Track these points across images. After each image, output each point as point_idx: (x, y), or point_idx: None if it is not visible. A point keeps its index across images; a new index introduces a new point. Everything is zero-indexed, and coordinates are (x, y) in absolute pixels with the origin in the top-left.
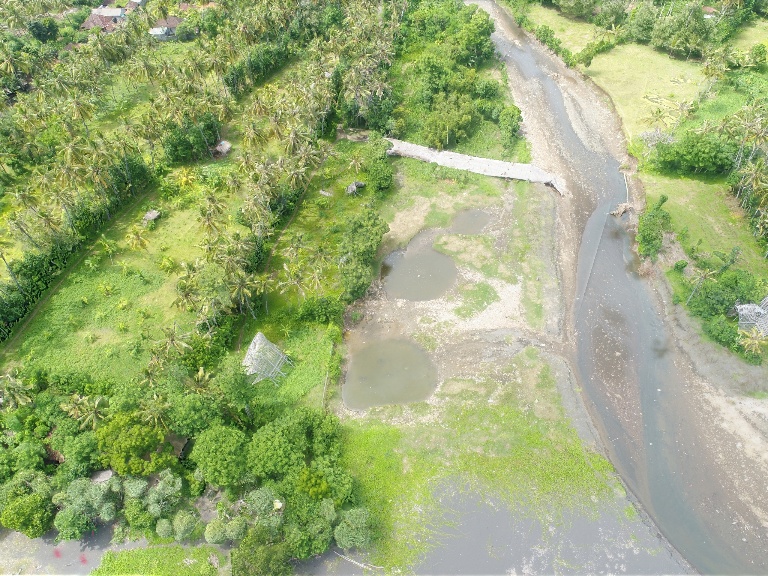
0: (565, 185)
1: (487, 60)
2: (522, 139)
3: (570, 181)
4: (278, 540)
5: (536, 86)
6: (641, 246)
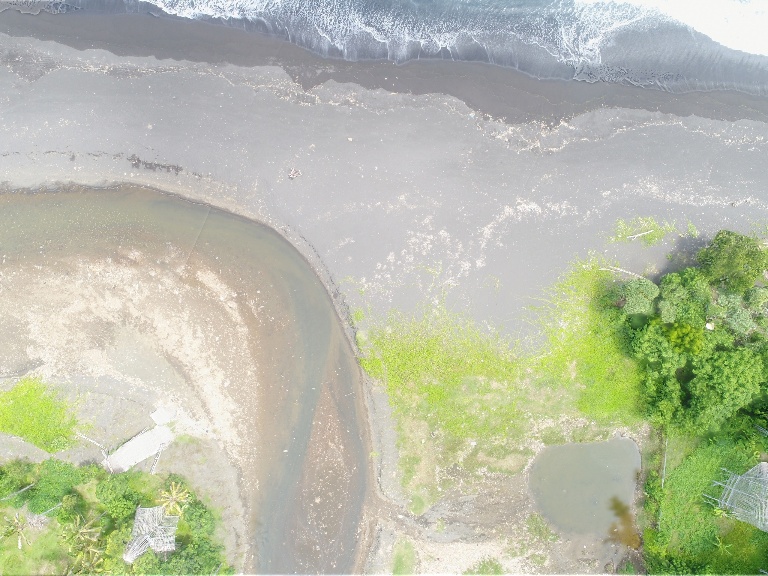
0: None
1: None
2: None
3: None
4: (716, 283)
5: None
6: None
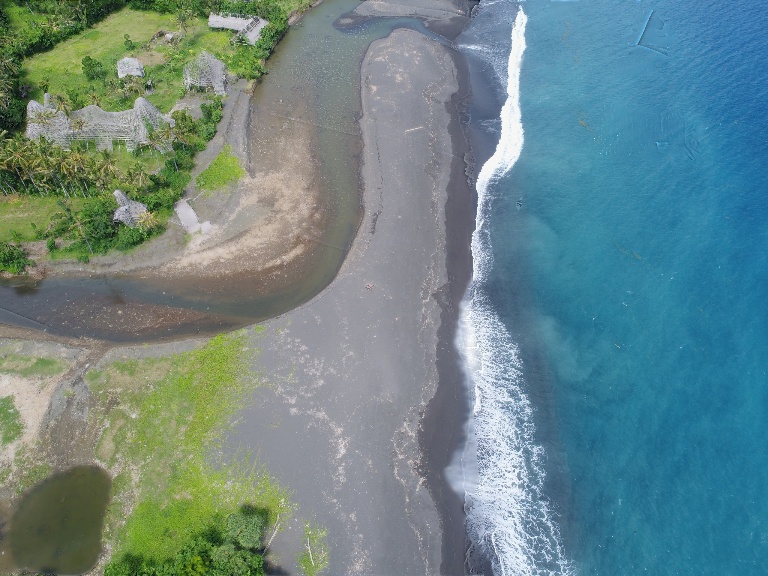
0: None
1: None
2: None
3: None
4: None
5: None
6: (10, 268)
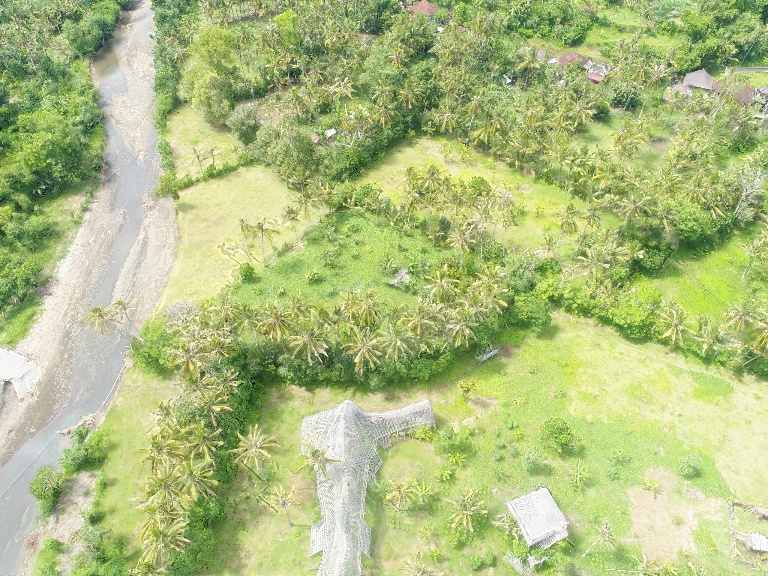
0: (36, 382)
1: (81, 181)
2: (37, 304)
3: (49, 375)
4: None
5: (117, 221)
6: None
